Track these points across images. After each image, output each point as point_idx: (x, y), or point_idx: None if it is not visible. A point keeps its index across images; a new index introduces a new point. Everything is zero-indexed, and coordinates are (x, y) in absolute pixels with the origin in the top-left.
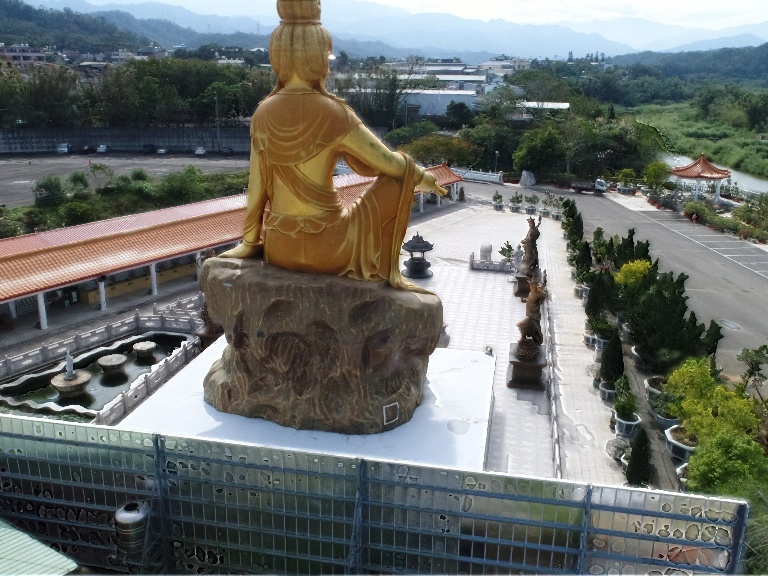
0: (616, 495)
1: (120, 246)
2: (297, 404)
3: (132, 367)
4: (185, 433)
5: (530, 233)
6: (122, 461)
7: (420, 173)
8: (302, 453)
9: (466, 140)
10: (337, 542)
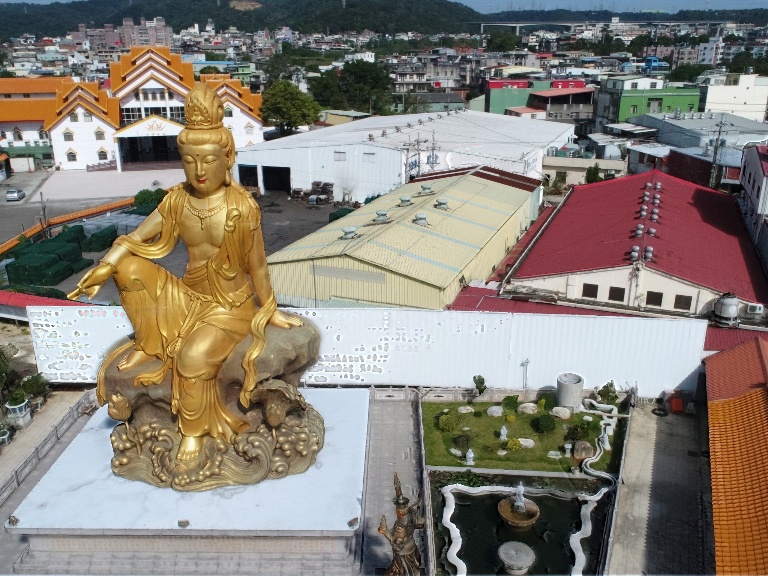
0: None
1: None
2: None
3: None
4: (317, 398)
5: None
6: None
7: None
8: None
9: None
10: None
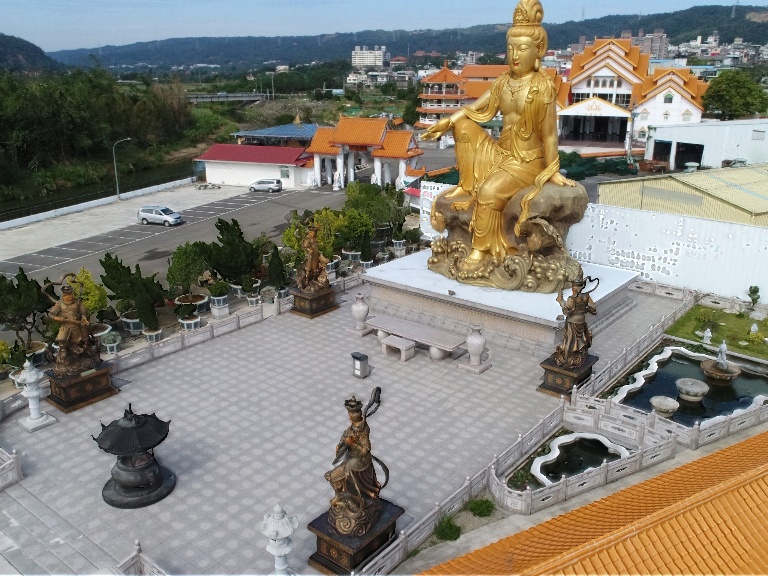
0: None
1: None
2: None
3: (677, 418)
4: (593, 268)
5: None
6: None
7: None
8: None
9: None
10: None
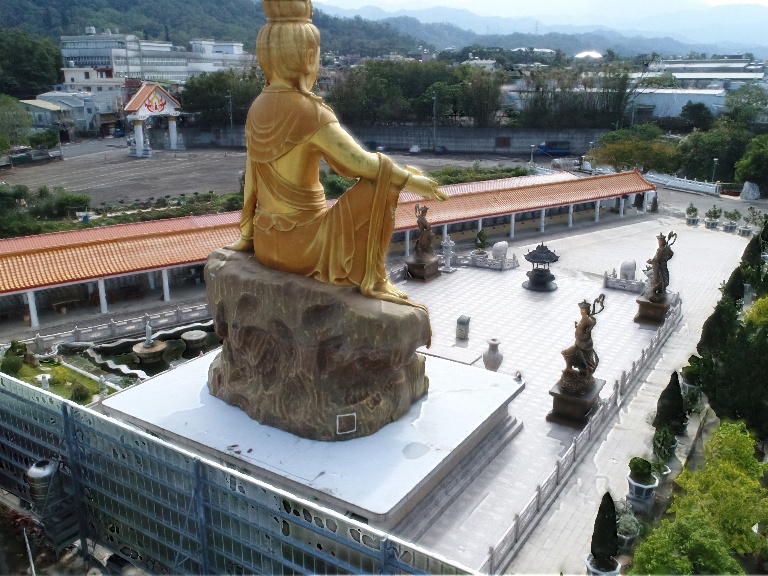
0: (414, 555)
1: None
2: (263, 399)
3: (217, 344)
4: (167, 409)
5: (658, 252)
6: (50, 422)
7: (404, 176)
8: (157, 443)
9: (668, 145)
10: (190, 537)
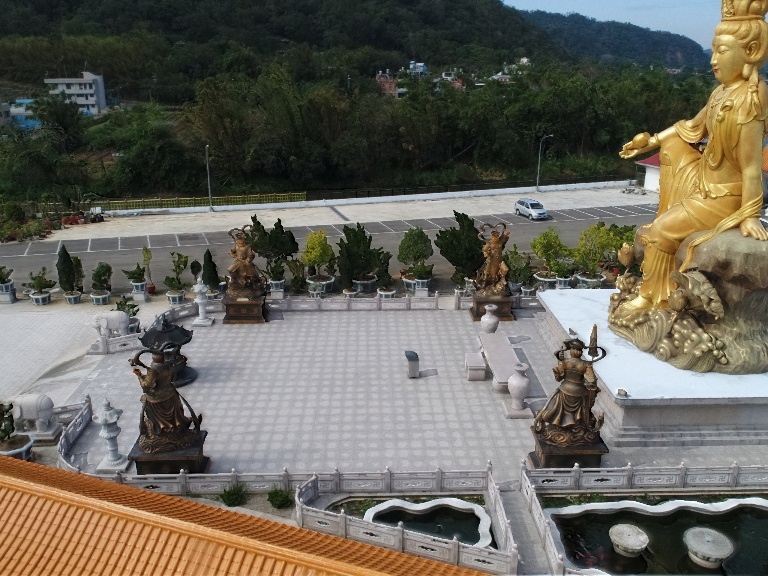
0: None
1: None
2: None
3: (655, 569)
4: None
5: None
6: None
7: None
8: None
9: None
10: None
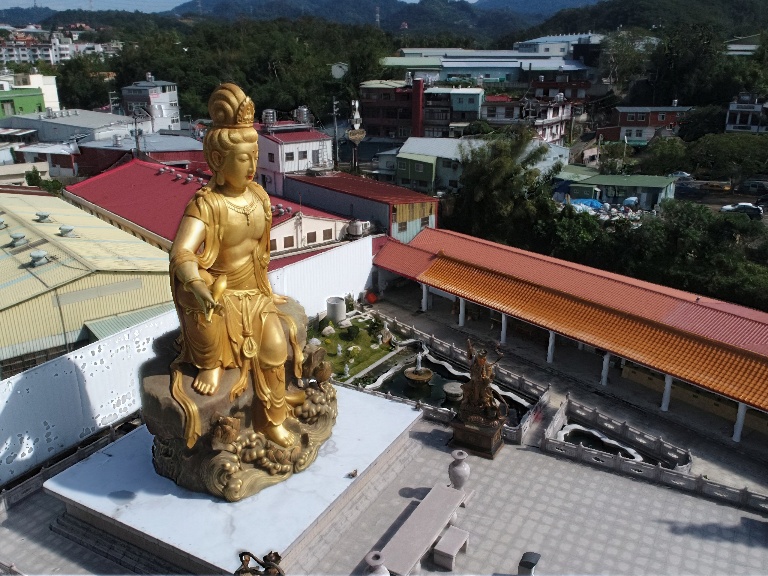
0: None
1: (652, 337)
2: None
3: None
4: None
5: None
6: (151, 338)
7: None
8: None
9: None
10: None
